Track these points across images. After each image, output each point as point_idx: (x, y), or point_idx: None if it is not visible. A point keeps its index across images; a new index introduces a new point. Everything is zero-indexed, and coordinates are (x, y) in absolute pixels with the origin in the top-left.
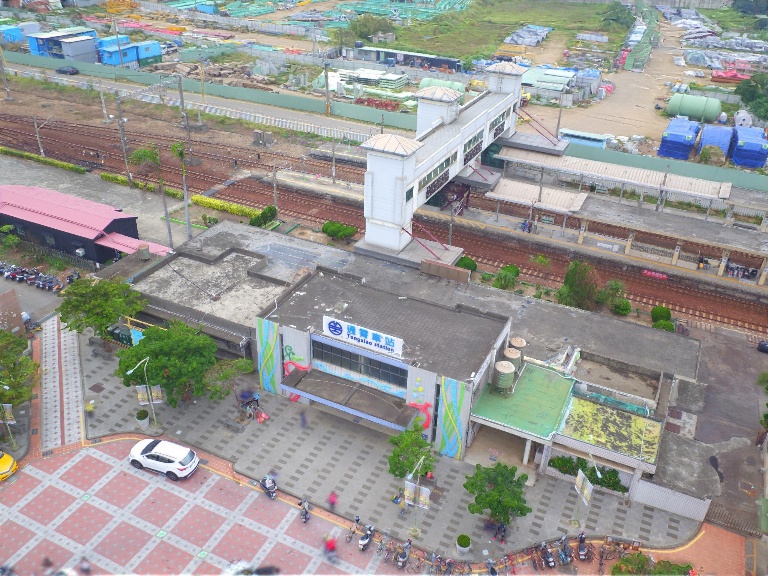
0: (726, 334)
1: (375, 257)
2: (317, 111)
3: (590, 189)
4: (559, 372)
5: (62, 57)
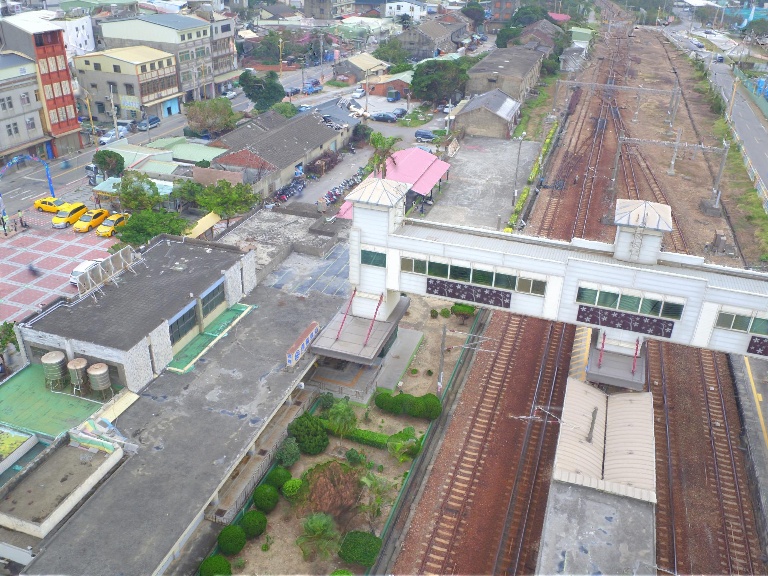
0: None
1: None
2: None
3: None
4: None
5: None
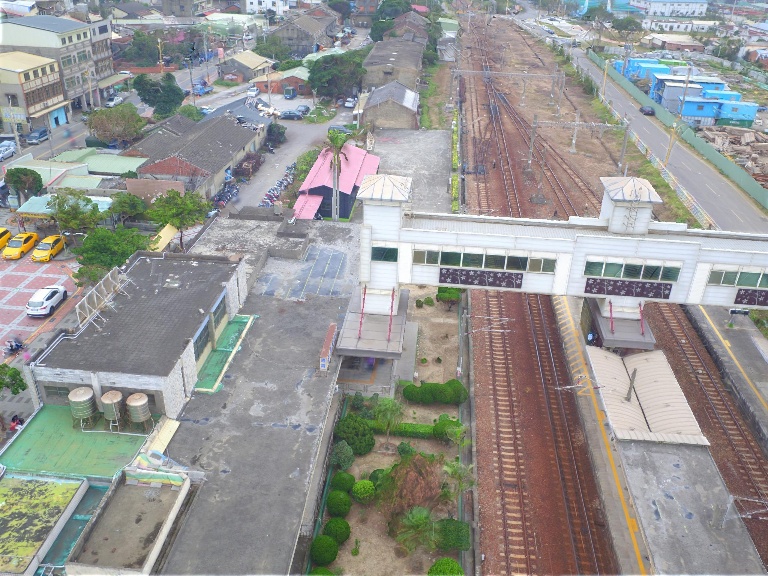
0: None
1: None
2: None
3: None
4: None
5: (661, 99)
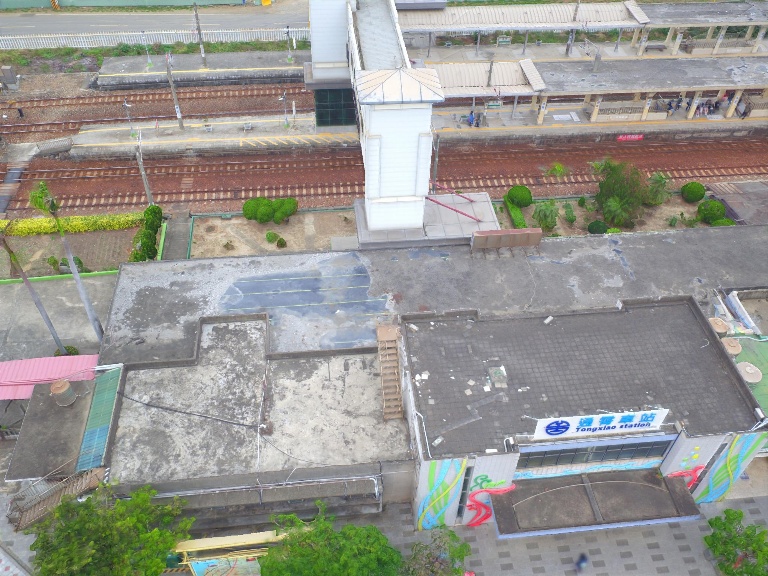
0: (752, 190)
1: (394, 248)
2: (34, 6)
3: (475, 41)
4: (749, 335)
5: None
